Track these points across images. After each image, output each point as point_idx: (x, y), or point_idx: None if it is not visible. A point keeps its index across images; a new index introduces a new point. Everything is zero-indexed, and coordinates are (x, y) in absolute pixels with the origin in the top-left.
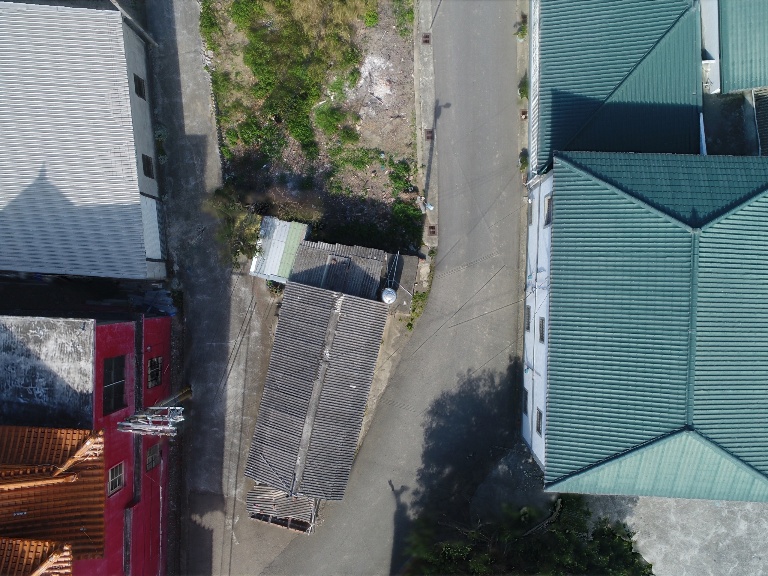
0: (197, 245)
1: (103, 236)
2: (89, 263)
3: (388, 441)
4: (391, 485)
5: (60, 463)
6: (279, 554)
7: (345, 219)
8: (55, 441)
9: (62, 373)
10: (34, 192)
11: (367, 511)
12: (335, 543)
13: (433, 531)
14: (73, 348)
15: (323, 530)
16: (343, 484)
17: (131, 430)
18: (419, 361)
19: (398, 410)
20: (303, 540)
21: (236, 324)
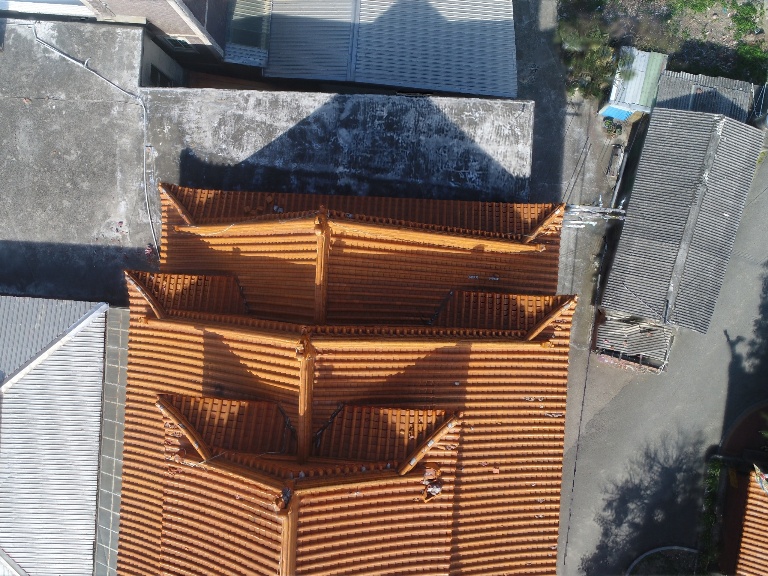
0: (529, 85)
1: (474, 52)
2: (459, 79)
3: (724, 290)
4: (726, 335)
5: (524, 234)
6: (610, 401)
7: (683, 62)
8: (512, 214)
9: (498, 156)
10: (406, 5)
11: (701, 361)
12: (667, 392)
13: (767, 384)
14: (510, 131)
15: (655, 378)
16: (709, 317)
17: (578, 212)
18: (759, 208)
19: (736, 258)
20: (635, 388)
21: (570, 165)
